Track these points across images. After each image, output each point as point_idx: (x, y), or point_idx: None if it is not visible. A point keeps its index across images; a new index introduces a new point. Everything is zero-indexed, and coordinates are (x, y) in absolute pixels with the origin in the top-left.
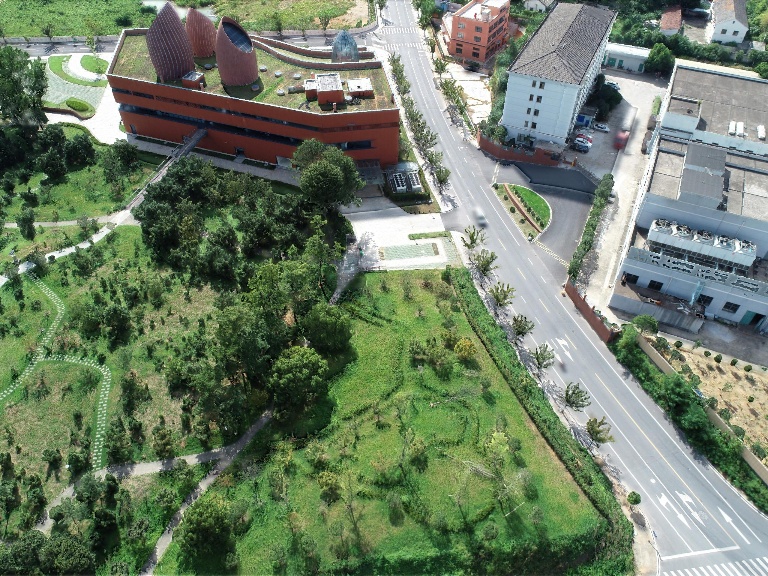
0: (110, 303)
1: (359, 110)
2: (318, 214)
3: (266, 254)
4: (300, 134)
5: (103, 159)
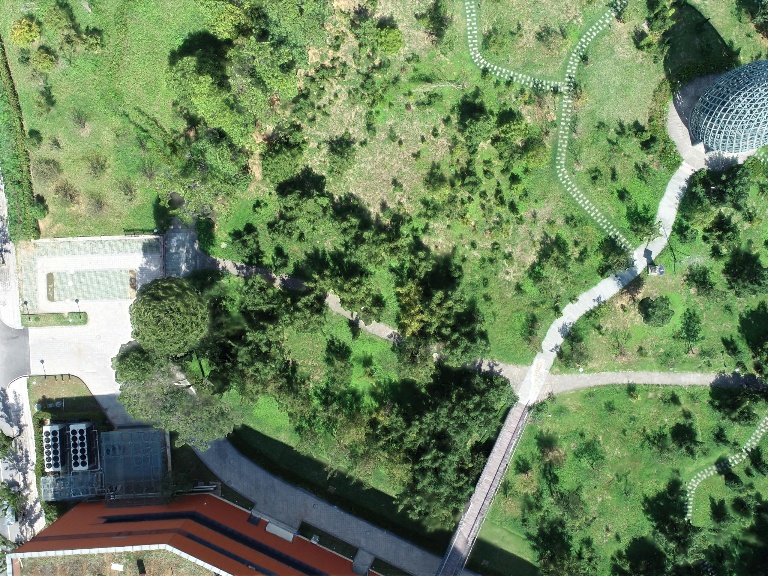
0: (499, 176)
1: (95, 574)
2: (207, 326)
3: (300, 284)
4: (228, 545)
5: (602, 569)
